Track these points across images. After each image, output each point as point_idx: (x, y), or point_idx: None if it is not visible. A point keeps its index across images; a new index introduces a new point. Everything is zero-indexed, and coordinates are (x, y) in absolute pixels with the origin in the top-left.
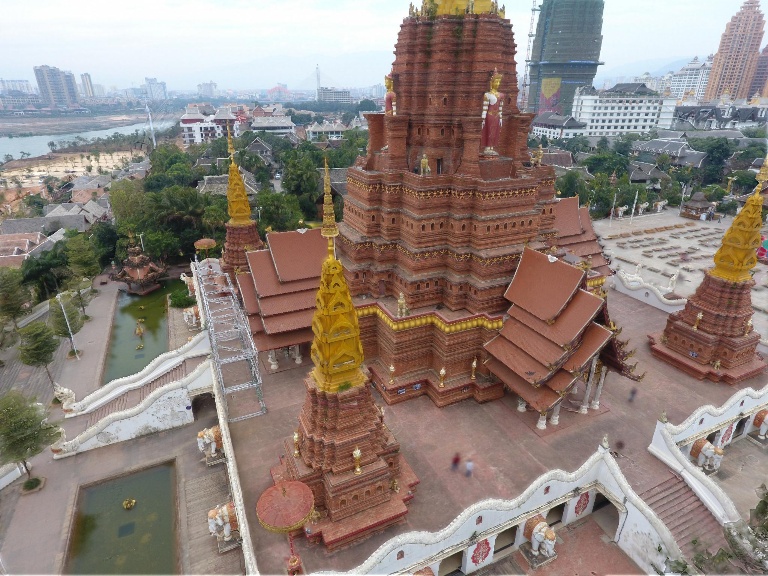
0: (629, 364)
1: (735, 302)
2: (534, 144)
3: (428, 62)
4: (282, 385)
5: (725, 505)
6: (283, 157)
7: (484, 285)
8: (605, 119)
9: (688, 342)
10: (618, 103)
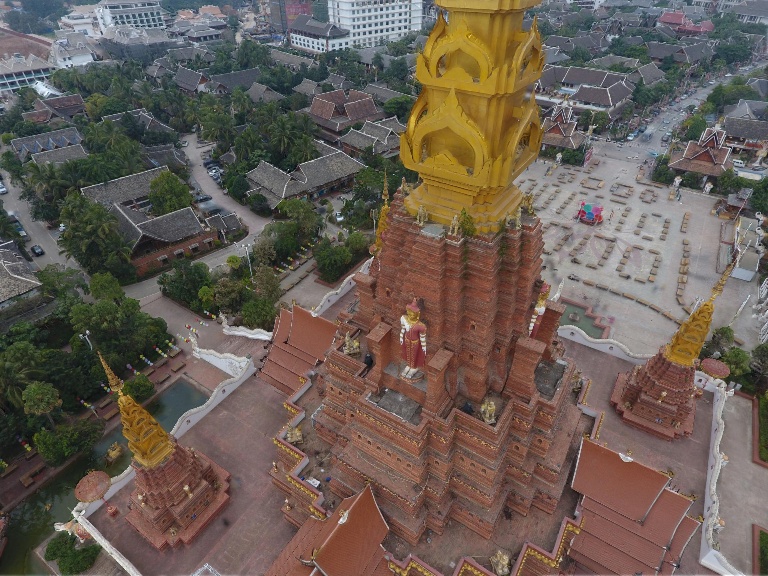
0: (618, 446)
1: (689, 379)
2: (316, 74)
3: (466, 285)
4: None
5: None
6: (3, 164)
7: (559, 491)
8: (365, 24)
9: (654, 412)
10: (373, 4)
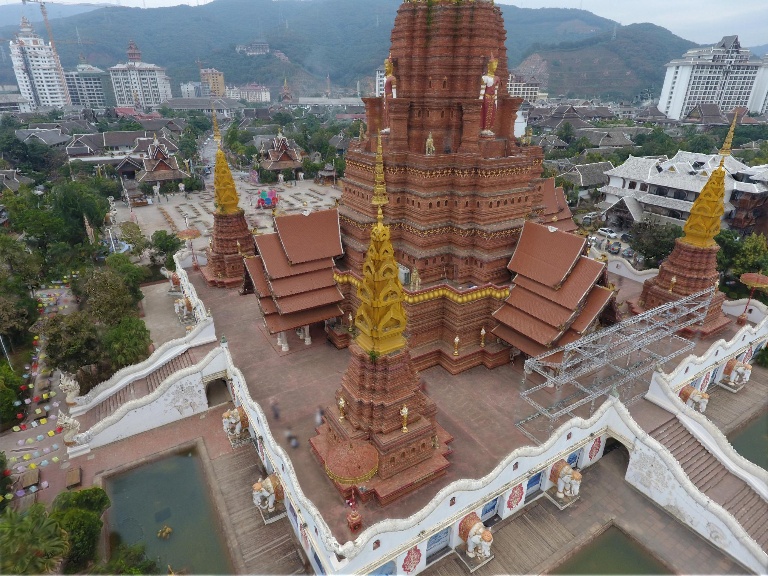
0: None
1: None
2: None
3: None
4: None
5: None
6: None
7: None
8: None
9: None
10: None
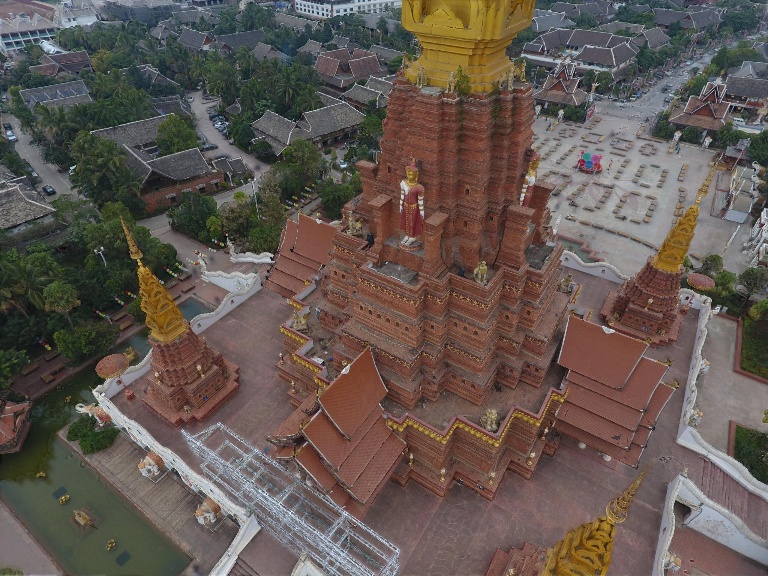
0: None
1: (674, 286)
2: (320, 36)
3: (461, 147)
4: (379, 532)
5: (742, 471)
6: (13, 110)
7: (545, 363)
8: None
9: (641, 320)
10: None
